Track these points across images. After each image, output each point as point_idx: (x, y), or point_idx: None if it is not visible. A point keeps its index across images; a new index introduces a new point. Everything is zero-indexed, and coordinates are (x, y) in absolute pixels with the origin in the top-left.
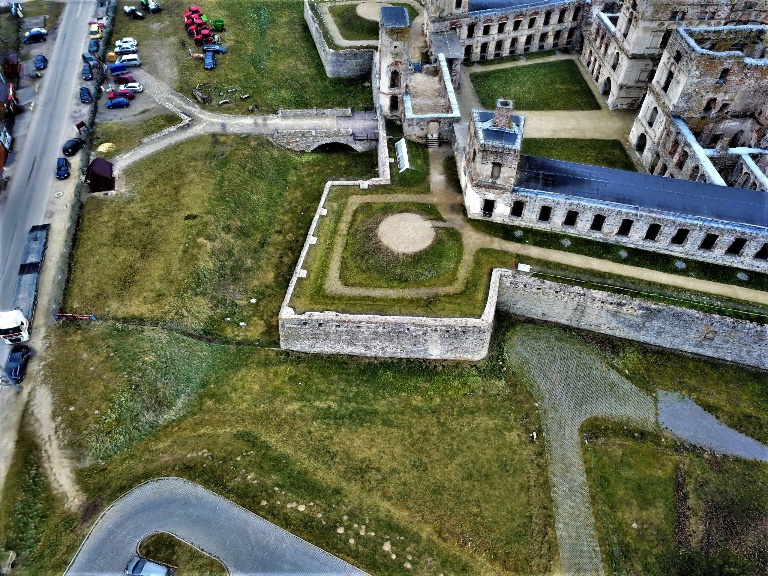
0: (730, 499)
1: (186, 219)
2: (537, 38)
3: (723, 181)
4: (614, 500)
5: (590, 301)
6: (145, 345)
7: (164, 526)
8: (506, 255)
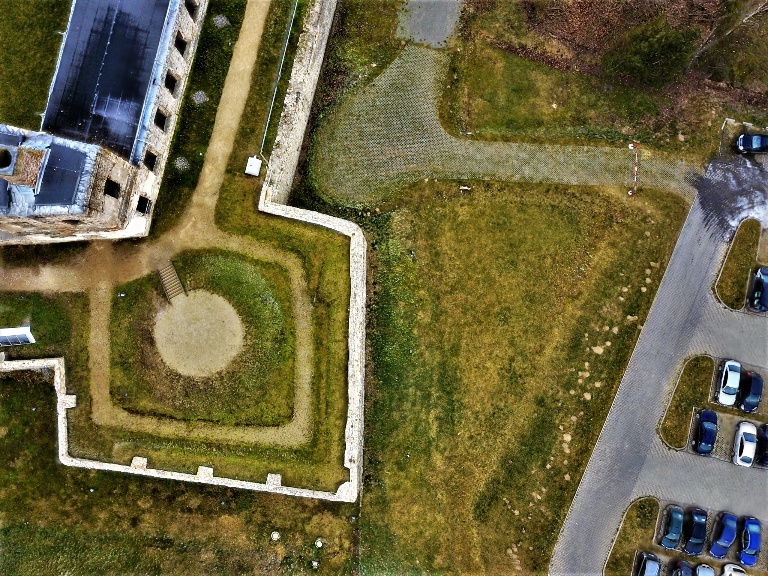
0: (525, 4)
1: None
2: None
3: None
4: (531, 120)
5: (303, 88)
6: None
7: (597, 574)
8: (229, 189)
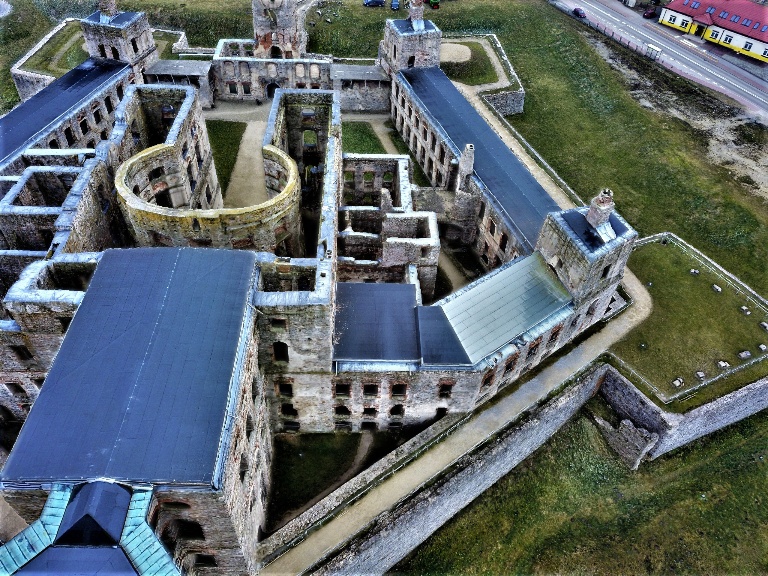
0: None
1: (182, 4)
2: (427, 159)
3: (32, 153)
4: None
5: None
6: (88, 0)
7: None
8: None
